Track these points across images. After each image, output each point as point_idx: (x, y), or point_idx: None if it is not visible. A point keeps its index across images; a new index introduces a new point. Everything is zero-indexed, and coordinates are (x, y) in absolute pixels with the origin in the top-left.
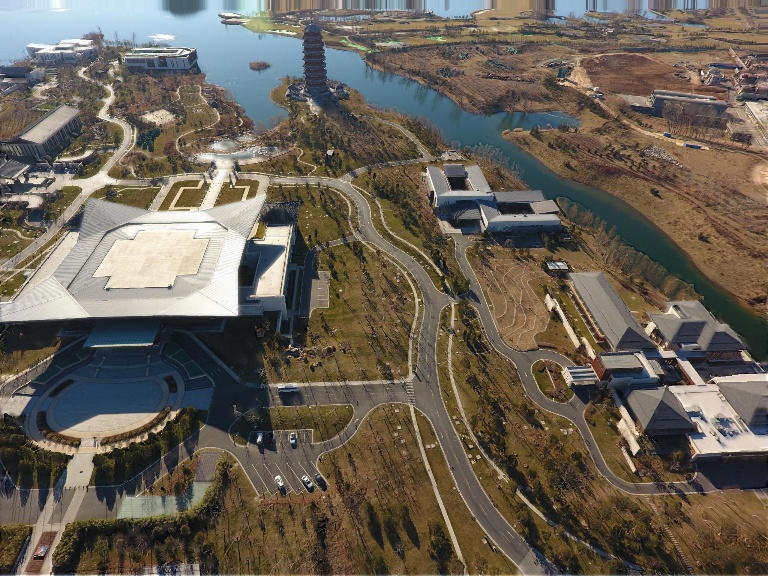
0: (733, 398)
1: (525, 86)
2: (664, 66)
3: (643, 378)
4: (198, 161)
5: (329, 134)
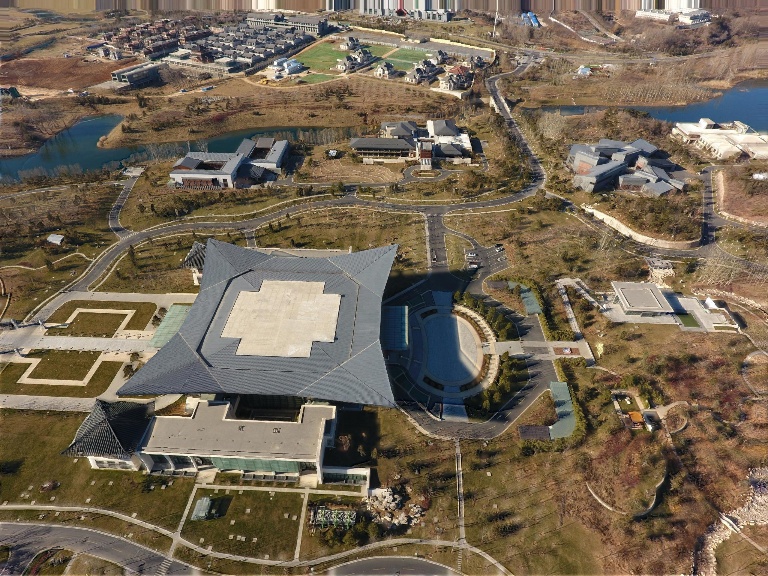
0: (444, 133)
1: (8, 116)
2: (61, 60)
3: (434, 146)
4: None
5: None
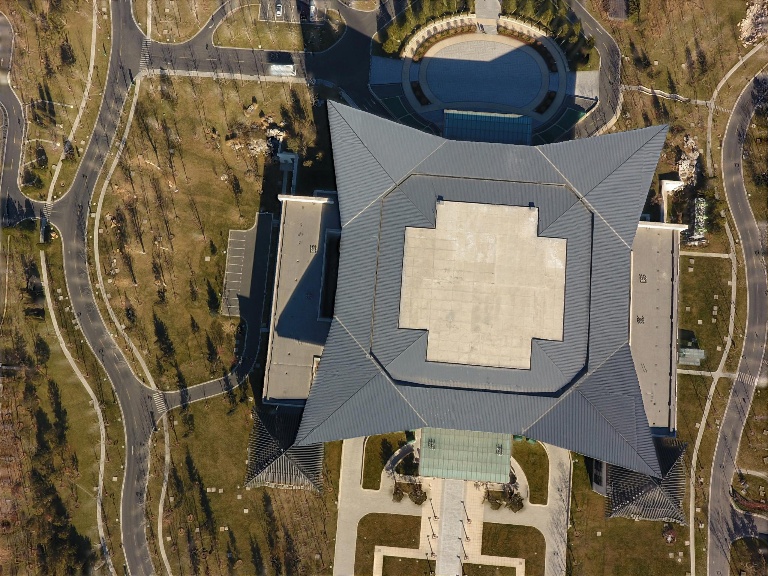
0: None
1: None
2: None
3: None
4: None
5: None
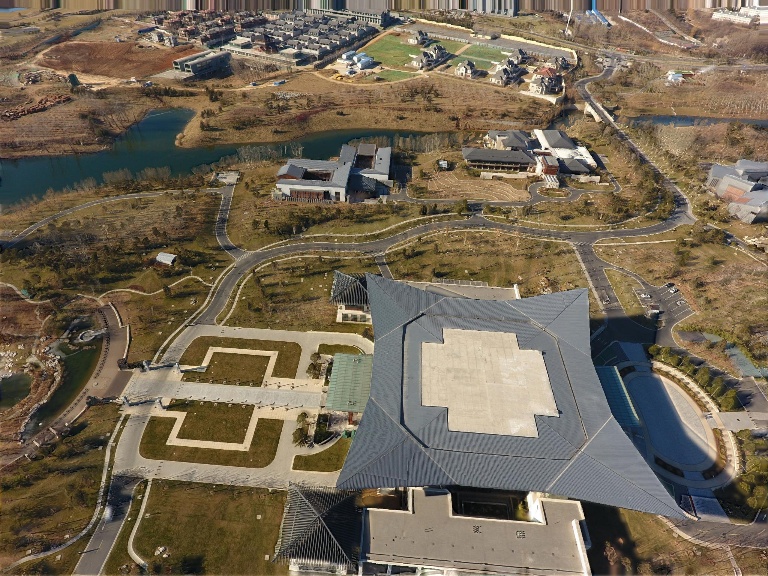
0: (561, 145)
1: (72, 106)
2: (114, 44)
3: None
4: (68, 426)
5: (111, 249)
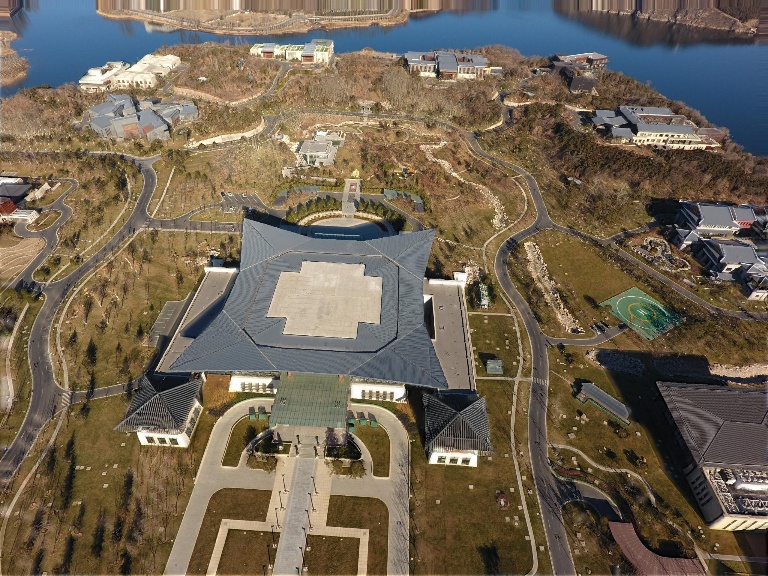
0: None
1: None
2: None
3: None
4: None
5: None
